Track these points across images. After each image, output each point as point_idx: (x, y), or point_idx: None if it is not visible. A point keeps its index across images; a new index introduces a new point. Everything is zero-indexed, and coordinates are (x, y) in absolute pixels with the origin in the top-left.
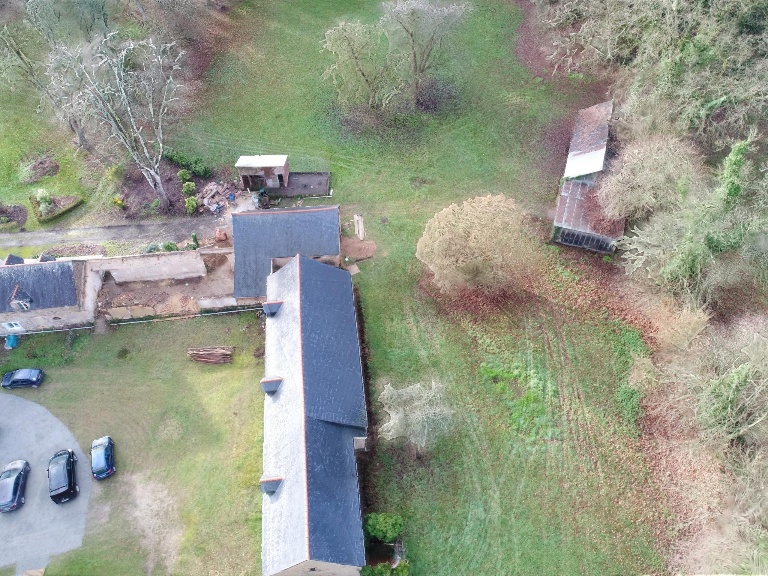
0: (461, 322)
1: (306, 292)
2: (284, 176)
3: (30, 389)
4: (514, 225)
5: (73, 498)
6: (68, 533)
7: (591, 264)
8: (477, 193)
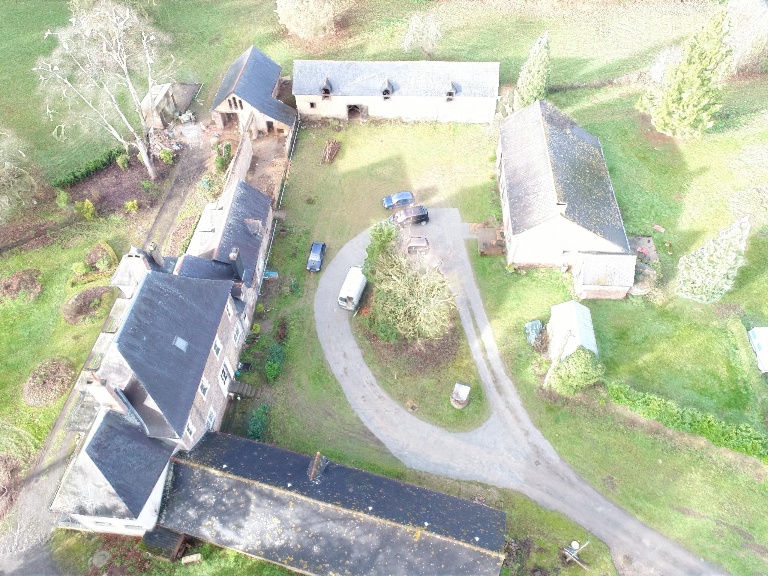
0: (349, 42)
1: None
2: (173, 95)
3: (326, 255)
4: None
5: None
6: (448, 215)
7: None
8: (243, 19)
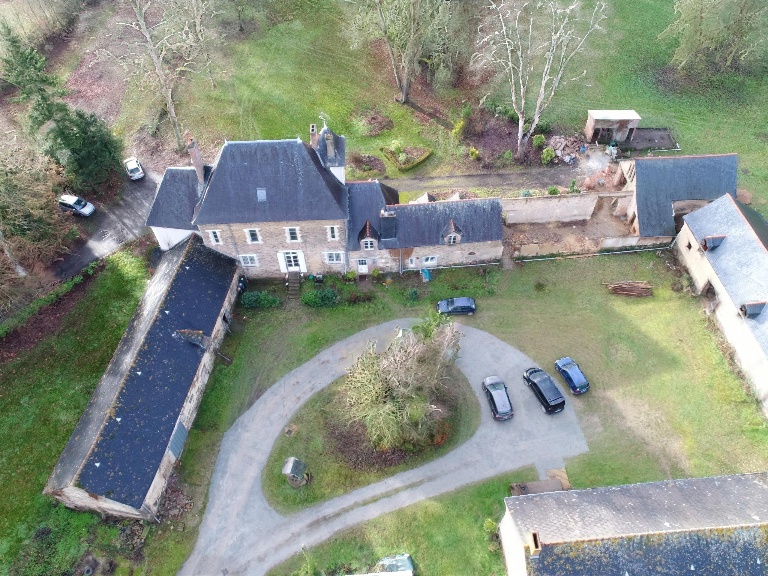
0: None
1: (753, 227)
2: (635, 129)
3: (465, 316)
4: None
5: (562, 409)
6: (571, 439)
7: None
8: None
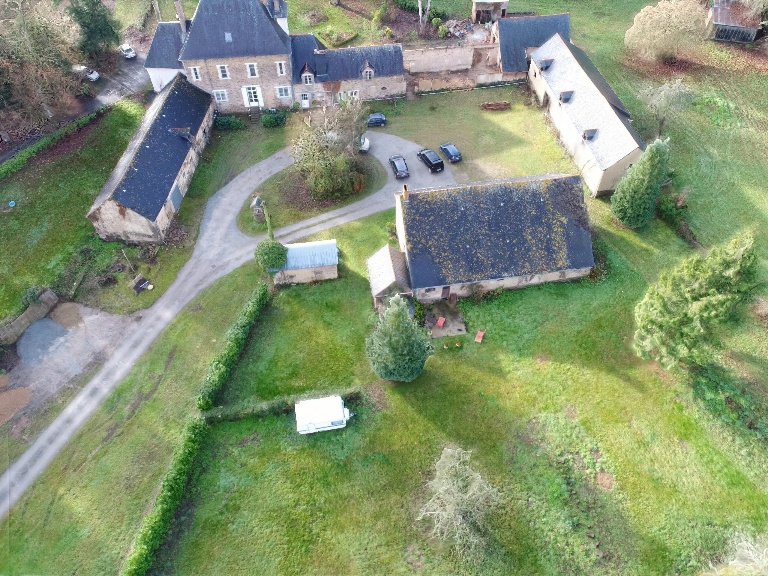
0: (661, 80)
1: None
2: None
3: (379, 127)
4: (701, 8)
5: (442, 170)
6: None
7: (739, 49)
8: None
